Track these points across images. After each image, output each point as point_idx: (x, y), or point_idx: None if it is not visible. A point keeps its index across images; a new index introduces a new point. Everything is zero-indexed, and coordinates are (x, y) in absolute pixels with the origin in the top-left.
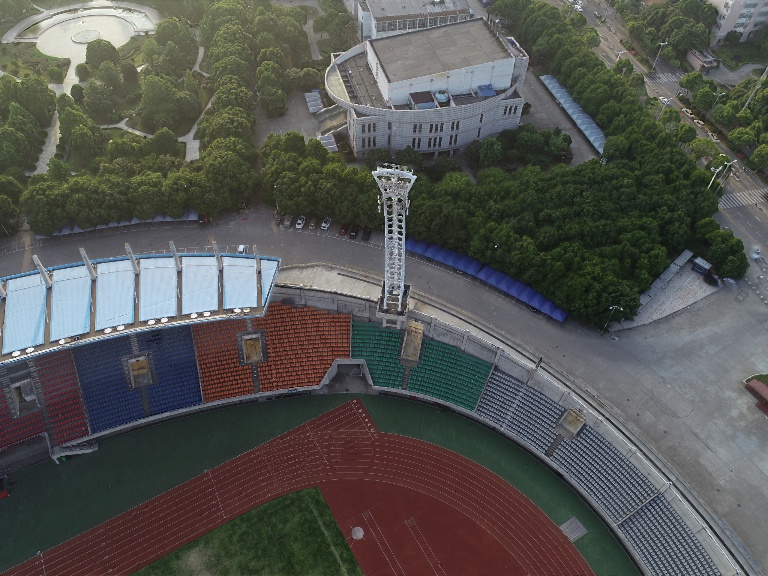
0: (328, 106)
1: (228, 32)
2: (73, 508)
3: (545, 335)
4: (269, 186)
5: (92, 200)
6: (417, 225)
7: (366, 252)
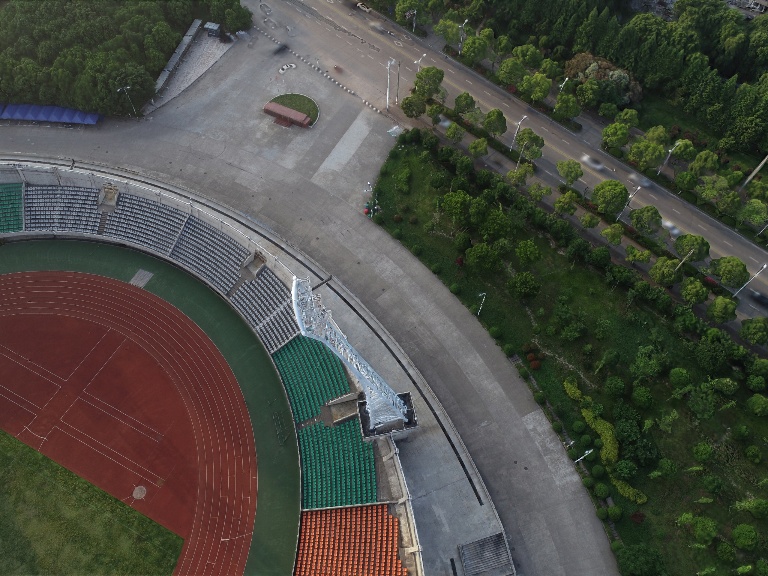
0: None
1: None
2: None
3: (85, 142)
4: None
5: None
6: None
7: None
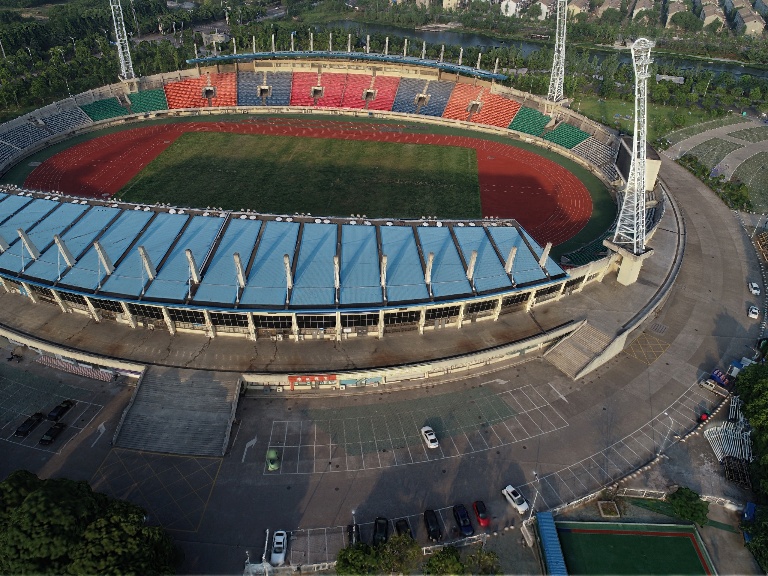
0: None
1: None
2: None
3: None
4: None
5: None
6: None
7: None
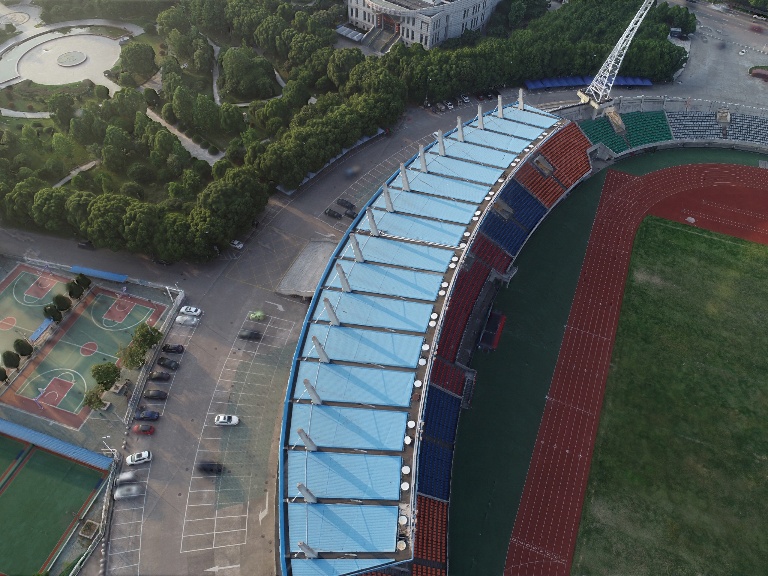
0: (362, 33)
1: (241, 0)
2: (549, 299)
3: None
4: (422, 83)
5: (321, 140)
6: (534, 67)
7: (508, 103)
